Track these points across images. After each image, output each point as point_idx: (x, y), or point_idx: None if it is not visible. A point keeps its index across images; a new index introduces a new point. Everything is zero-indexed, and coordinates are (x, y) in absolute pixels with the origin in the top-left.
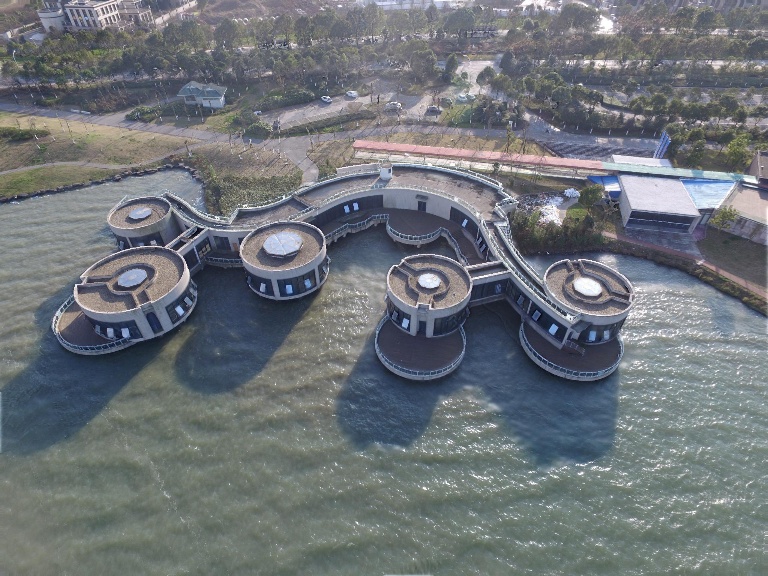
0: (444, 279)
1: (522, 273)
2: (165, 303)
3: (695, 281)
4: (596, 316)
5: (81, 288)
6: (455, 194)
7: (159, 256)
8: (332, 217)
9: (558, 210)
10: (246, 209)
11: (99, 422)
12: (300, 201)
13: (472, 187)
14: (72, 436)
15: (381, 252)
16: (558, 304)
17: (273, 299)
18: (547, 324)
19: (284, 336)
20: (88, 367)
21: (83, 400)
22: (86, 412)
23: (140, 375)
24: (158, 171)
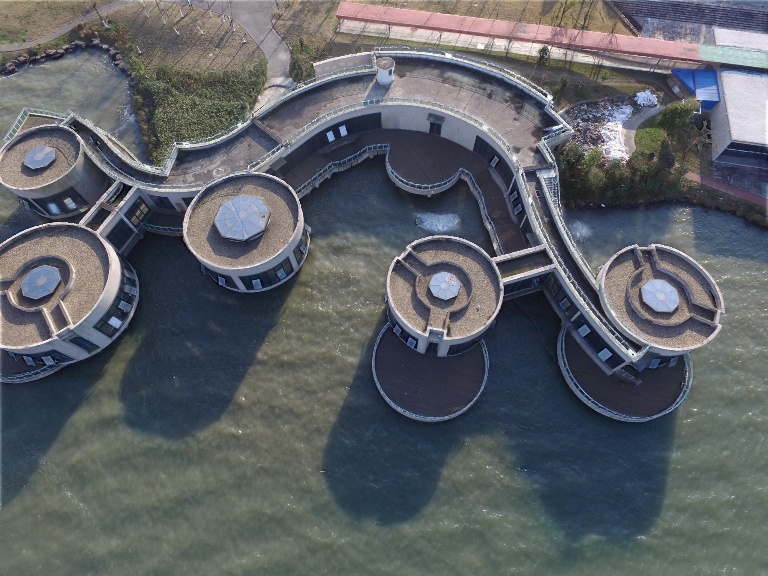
0: (465, 281)
1: (571, 266)
2: (91, 323)
3: None
4: (668, 350)
5: None
6: (483, 113)
7: (74, 239)
8: (311, 149)
9: (624, 131)
10: (188, 147)
11: (39, 482)
12: (264, 130)
13: (508, 98)
14: (8, 505)
15: (379, 204)
16: (617, 326)
17: (238, 291)
18: (597, 344)
19: (256, 349)
20: (12, 403)
21: (14, 453)
22: (20, 469)
23: (80, 412)
24: (65, 53)
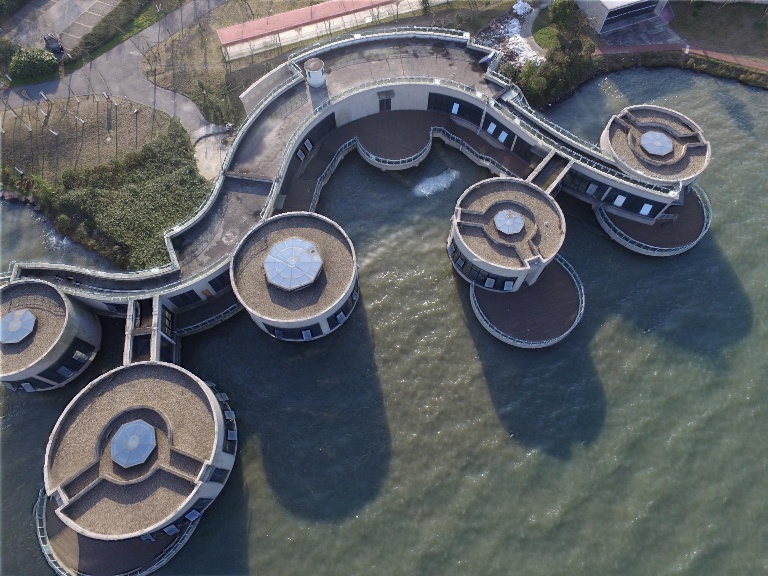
0: (519, 210)
1: None
2: (220, 447)
3: (691, 75)
4: (692, 178)
5: (67, 509)
6: (422, 71)
7: (132, 382)
8: (290, 176)
9: (525, 40)
10: (179, 231)
11: None
12: (241, 178)
13: (432, 51)
14: None
15: (380, 194)
16: (648, 181)
17: (320, 337)
18: (634, 205)
19: (375, 376)
20: None
21: None
22: None
23: (254, 544)
24: None
